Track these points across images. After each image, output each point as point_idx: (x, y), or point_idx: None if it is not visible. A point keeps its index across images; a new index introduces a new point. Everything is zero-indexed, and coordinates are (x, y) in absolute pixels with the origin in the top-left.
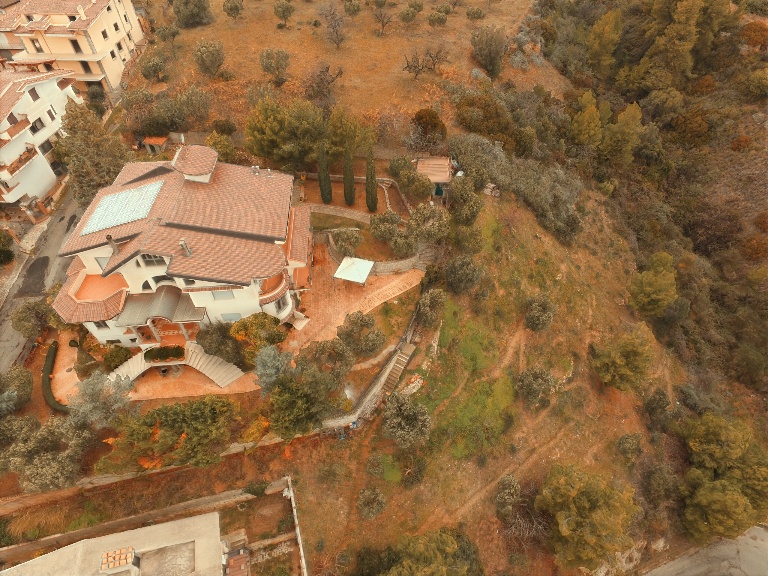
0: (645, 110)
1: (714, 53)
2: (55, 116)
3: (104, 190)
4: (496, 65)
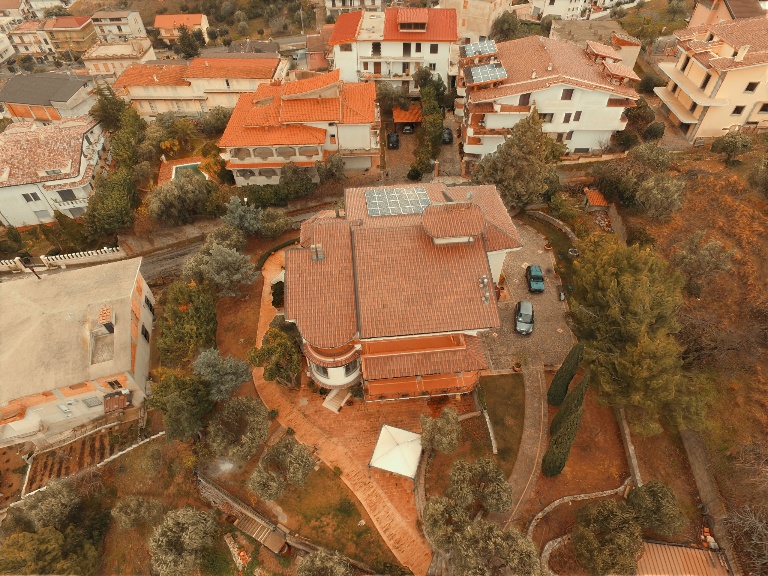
0: None
1: None
2: (571, 121)
3: (439, 184)
4: None
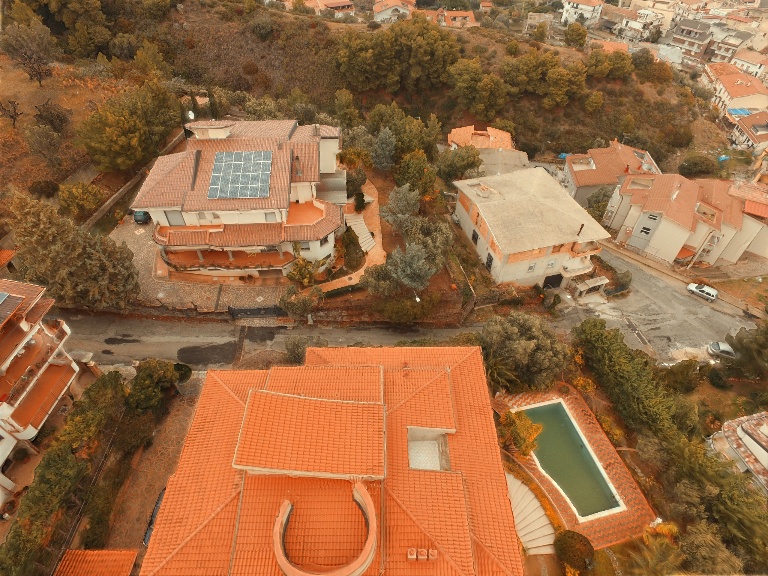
0: (124, 55)
1: (104, 4)
2: None
3: (189, 205)
4: (49, 57)
